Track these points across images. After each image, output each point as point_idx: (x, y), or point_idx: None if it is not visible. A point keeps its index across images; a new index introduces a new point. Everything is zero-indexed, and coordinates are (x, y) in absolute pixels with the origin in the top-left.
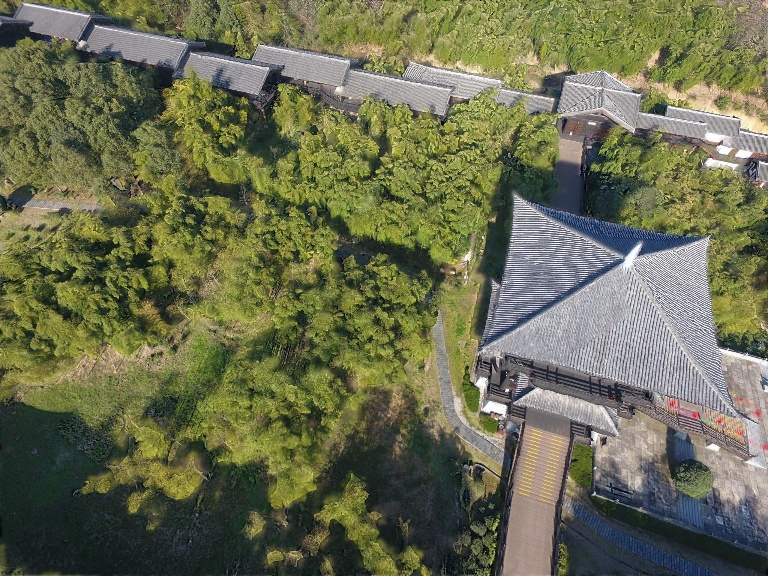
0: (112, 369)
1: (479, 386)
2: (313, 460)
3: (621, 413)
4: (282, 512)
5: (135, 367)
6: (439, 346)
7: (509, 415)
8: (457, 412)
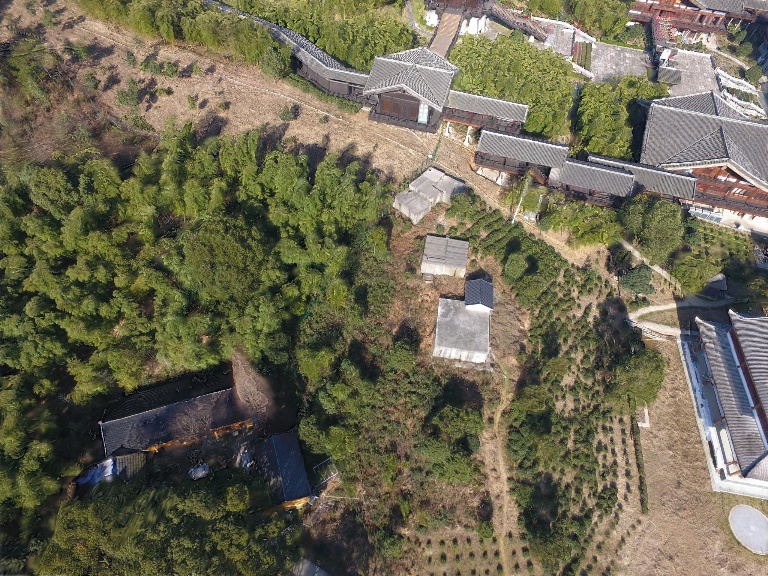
0: (260, 1)
1: (427, 20)
2: (354, 4)
3: (485, 11)
4: (344, 5)
5: (269, 2)
6: (409, 11)
7: (436, 7)
8: (416, 26)
